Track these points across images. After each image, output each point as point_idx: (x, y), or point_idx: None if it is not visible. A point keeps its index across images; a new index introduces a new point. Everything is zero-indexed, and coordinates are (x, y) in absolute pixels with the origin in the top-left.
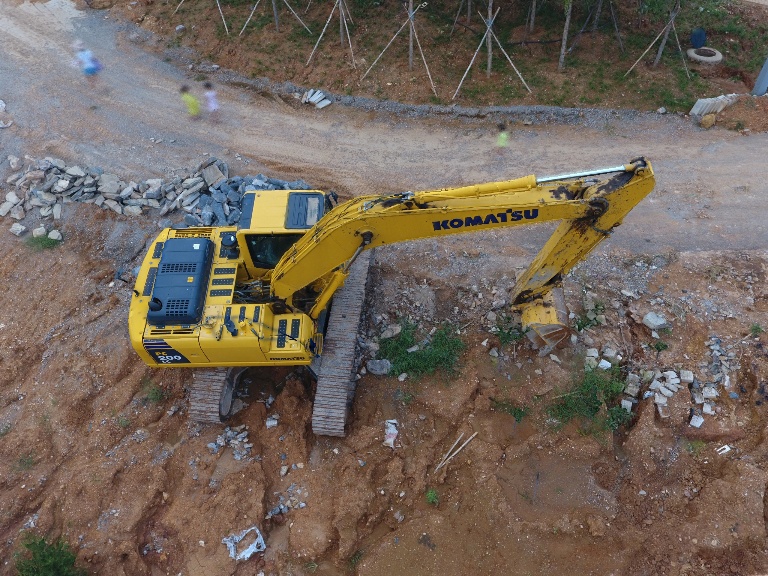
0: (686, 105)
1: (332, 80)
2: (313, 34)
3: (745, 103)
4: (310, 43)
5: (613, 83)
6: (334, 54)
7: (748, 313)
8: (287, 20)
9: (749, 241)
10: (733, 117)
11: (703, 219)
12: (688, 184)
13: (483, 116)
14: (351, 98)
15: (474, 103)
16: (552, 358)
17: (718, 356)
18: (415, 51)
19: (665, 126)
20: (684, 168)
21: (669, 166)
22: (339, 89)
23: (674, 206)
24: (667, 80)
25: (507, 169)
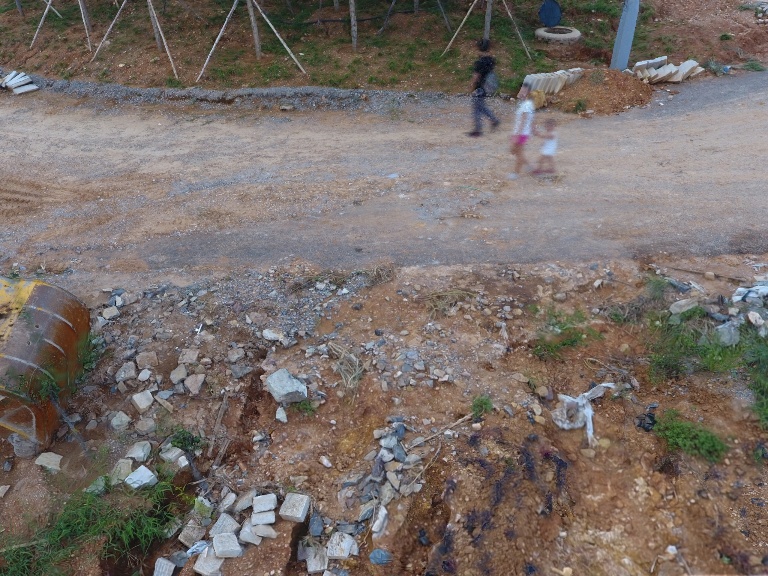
0: (514, 85)
1: (54, 64)
2: (63, 18)
3: (590, 77)
4: (52, 26)
5: (424, 63)
6: (71, 36)
7: (482, 373)
8: (42, 6)
9: (528, 250)
10: (573, 96)
11: (468, 219)
12: (470, 174)
13: (230, 101)
14: (64, 82)
15: (221, 85)
16: (38, 461)
17: (387, 461)
18: (180, 33)
19: (476, 109)
20: (476, 155)
21: (455, 153)
22: (58, 74)
23: (431, 202)
24: (496, 58)
25: (213, 158)
